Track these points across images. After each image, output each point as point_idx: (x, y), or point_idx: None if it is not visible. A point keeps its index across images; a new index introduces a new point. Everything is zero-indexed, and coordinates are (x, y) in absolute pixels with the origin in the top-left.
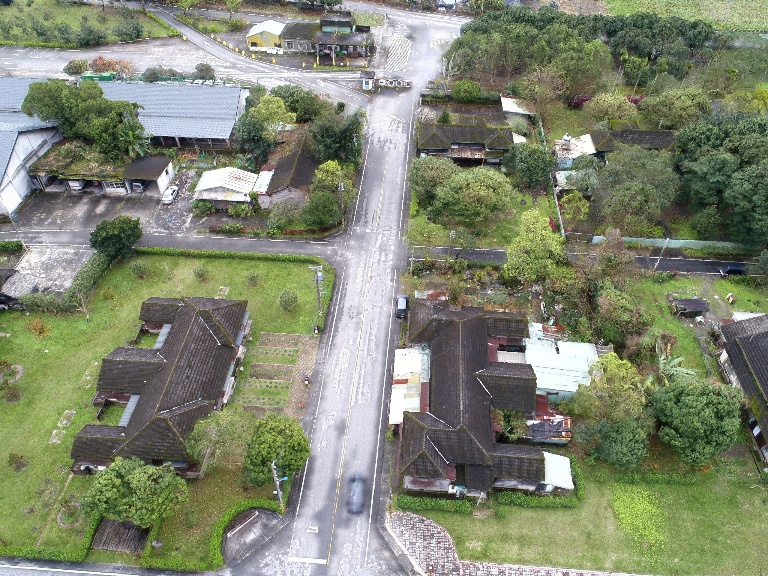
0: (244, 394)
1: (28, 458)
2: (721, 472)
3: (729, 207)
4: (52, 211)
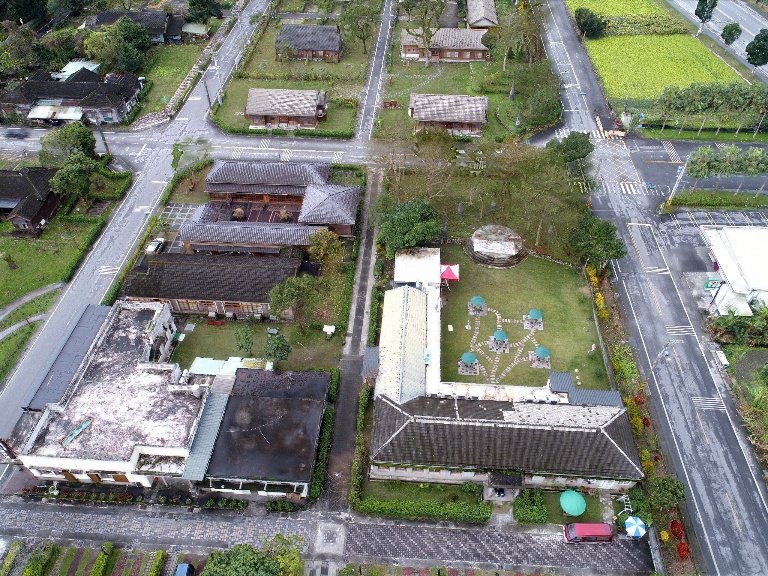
0: None
1: None
2: (156, 53)
3: (12, 1)
4: None
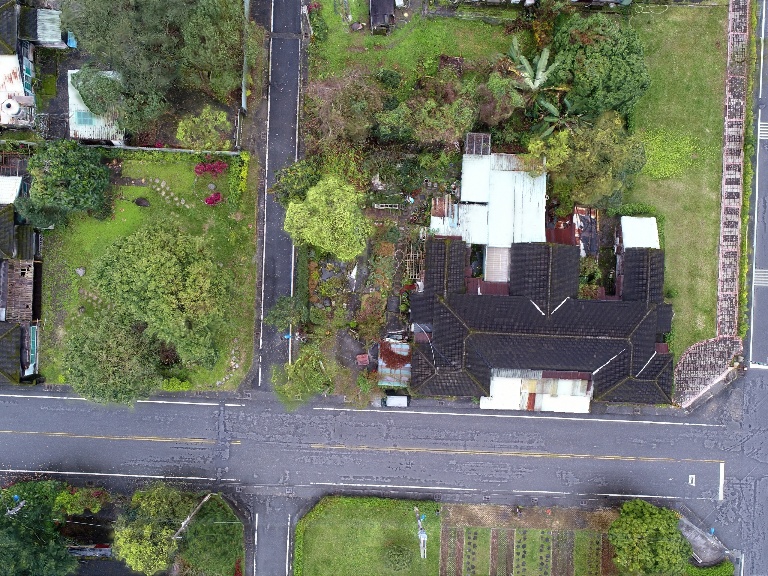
0: None
1: None
2: None
3: None
4: None
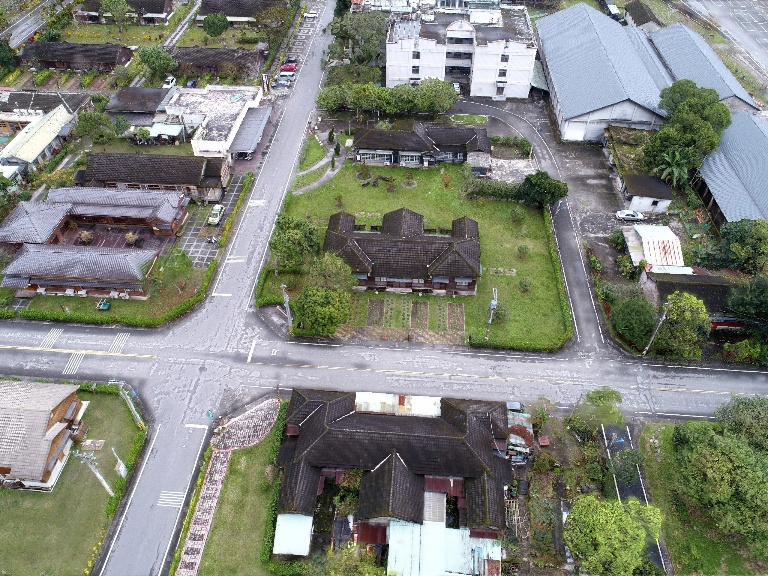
0: (396, 300)
1: (344, 207)
2: None
3: None
4: (579, 159)
